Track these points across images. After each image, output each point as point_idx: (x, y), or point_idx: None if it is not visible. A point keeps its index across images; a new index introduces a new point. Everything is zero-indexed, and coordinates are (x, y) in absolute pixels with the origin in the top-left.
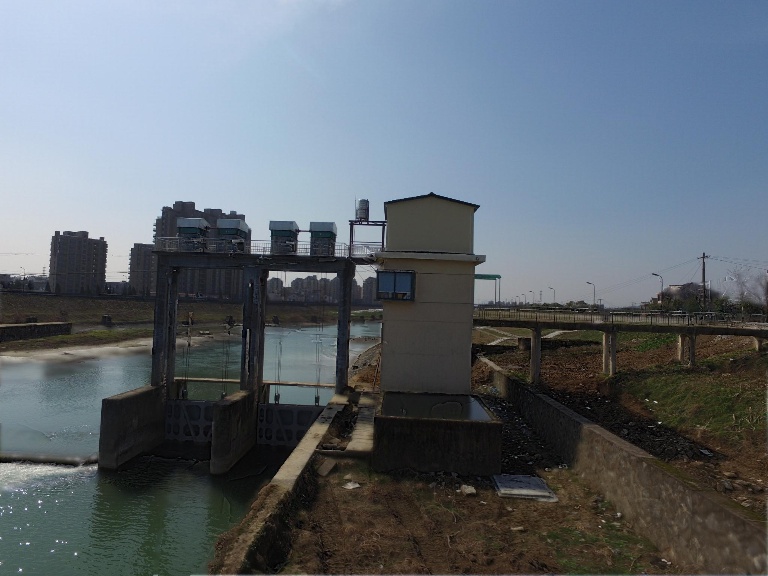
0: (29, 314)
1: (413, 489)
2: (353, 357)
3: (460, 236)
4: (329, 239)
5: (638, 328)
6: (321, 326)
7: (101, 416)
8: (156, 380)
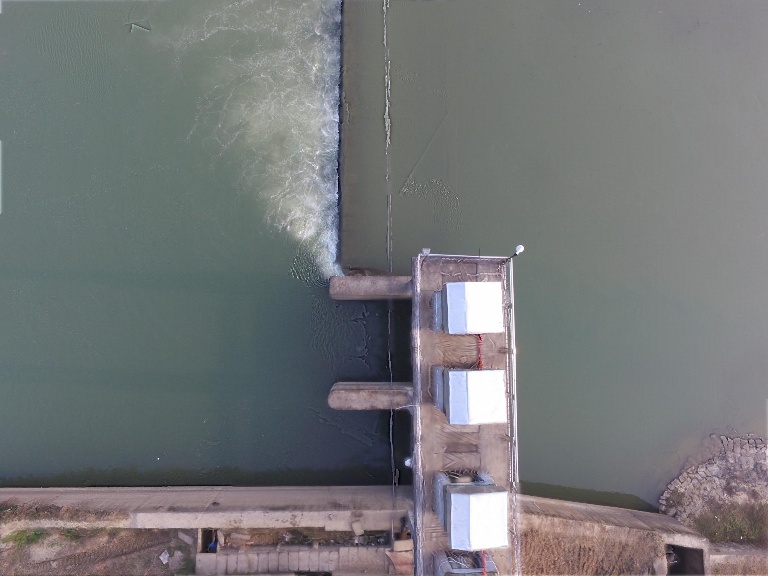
0: None
1: None
2: None
3: None
4: None
5: None
6: None
7: None
8: None
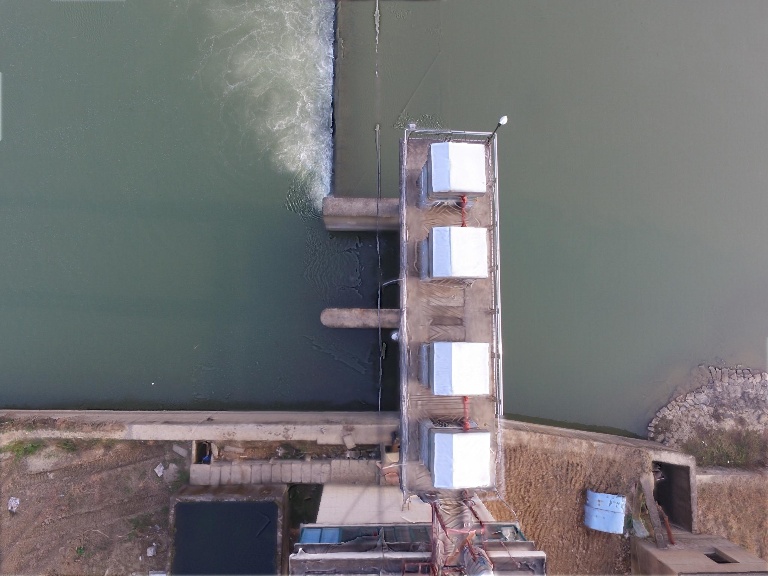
0: None
1: (151, 513)
2: None
3: None
4: (428, 468)
5: None
6: None
7: None
8: None
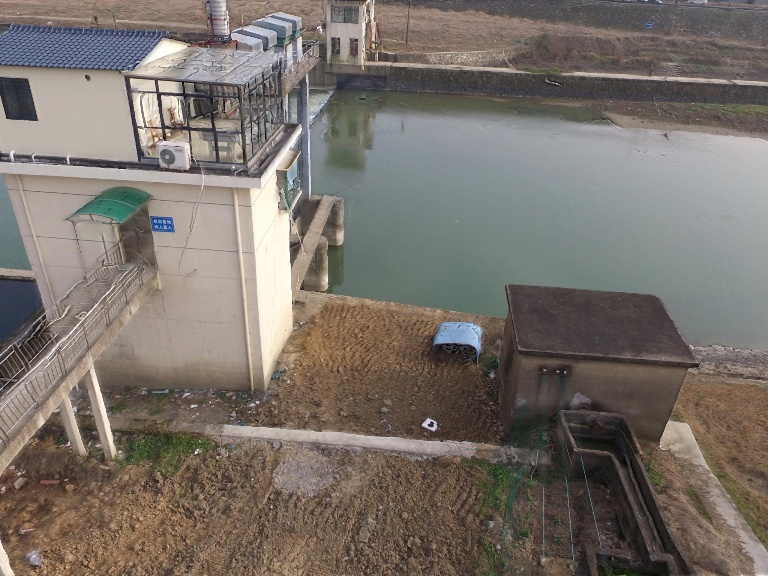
0: None
1: None
2: None
3: None
4: None
5: None
6: None
7: None
8: None
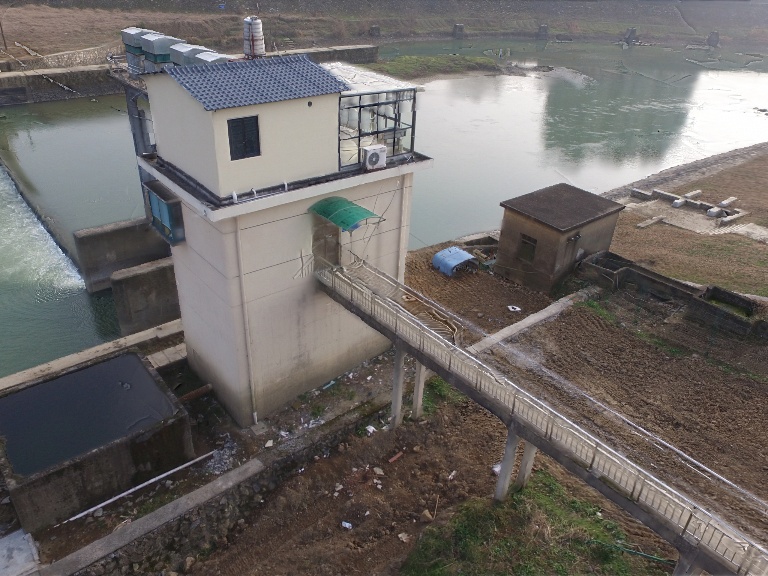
0: (382, 19)
1: None
2: (661, 167)
3: (209, 158)
4: None
5: (557, 456)
6: (763, 67)
7: (76, 247)
8: (148, 214)
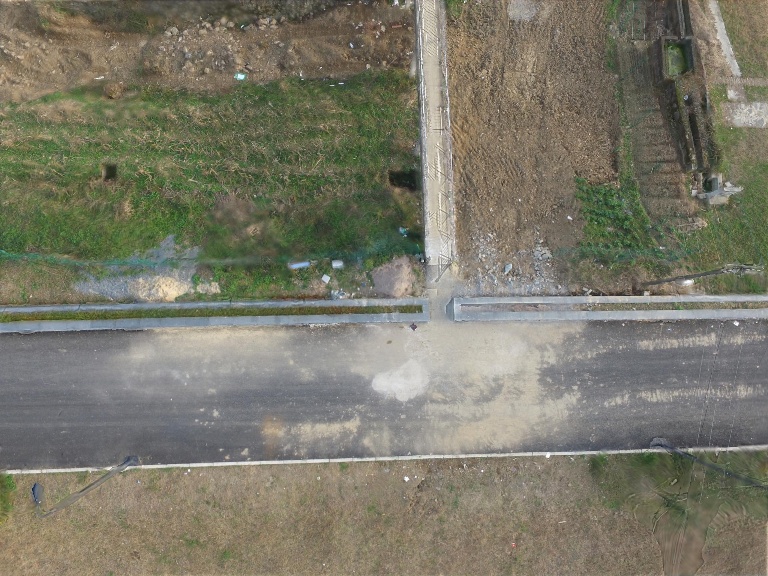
0: None
1: None
2: None
3: None
4: None
5: None
6: None
7: None
8: None
